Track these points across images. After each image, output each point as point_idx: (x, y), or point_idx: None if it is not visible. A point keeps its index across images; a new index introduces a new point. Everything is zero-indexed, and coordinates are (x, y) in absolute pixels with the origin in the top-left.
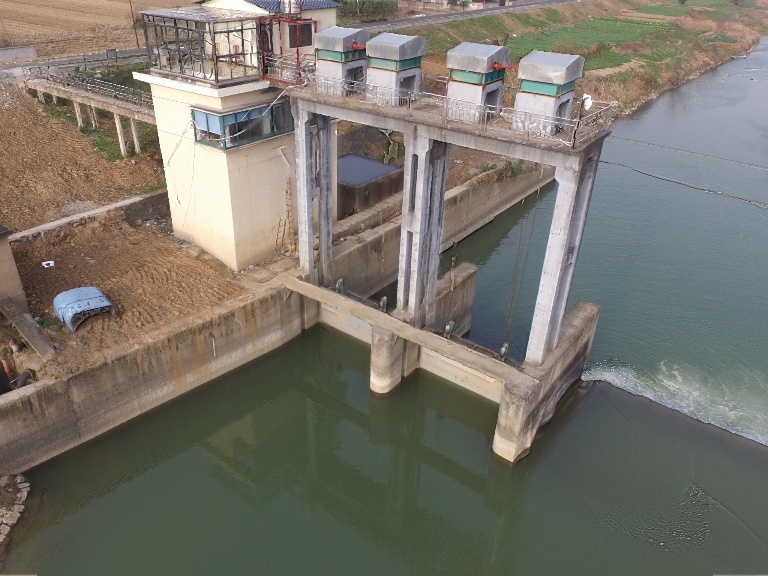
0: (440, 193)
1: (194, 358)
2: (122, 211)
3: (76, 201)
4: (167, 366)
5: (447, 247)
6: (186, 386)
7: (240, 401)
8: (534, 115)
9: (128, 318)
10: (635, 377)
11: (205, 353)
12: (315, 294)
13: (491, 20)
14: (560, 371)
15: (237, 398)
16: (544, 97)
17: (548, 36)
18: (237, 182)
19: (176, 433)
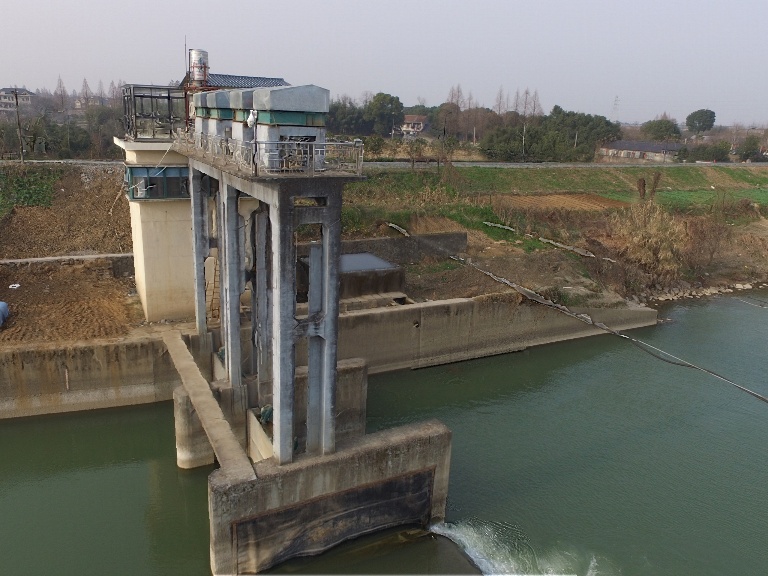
0: (266, 253)
1: (43, 383)
2: (111, 261)
3: (89, 249)
4: (11, 382)
5: (436, 363)
6: (32, 409)
7: (99, 448)
8: (238, 142)
9: (6, 332)
10: (512, 552)
11: (56, 382)
12: (173, 350)
13: (687, 171)
14: (336, 489)
15: (95, 443)
16: (264, 126)
17: (761, 192)
18: (152, 234)
19: (18, 456)
